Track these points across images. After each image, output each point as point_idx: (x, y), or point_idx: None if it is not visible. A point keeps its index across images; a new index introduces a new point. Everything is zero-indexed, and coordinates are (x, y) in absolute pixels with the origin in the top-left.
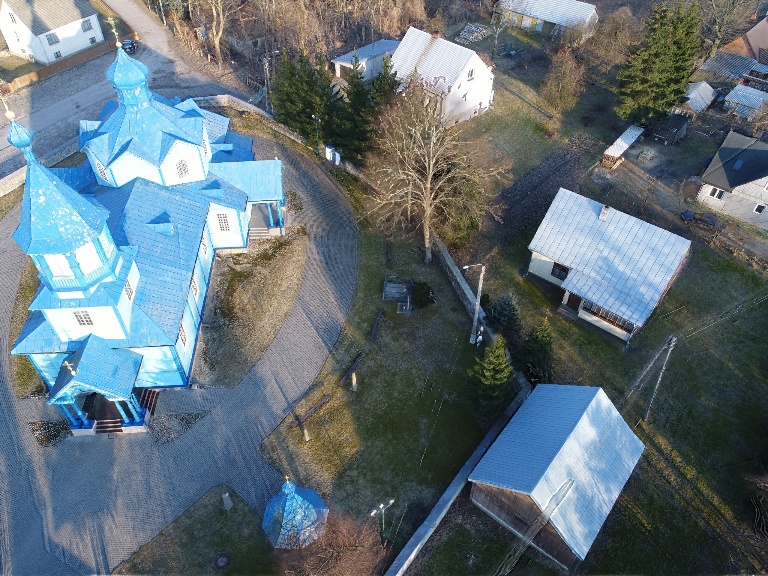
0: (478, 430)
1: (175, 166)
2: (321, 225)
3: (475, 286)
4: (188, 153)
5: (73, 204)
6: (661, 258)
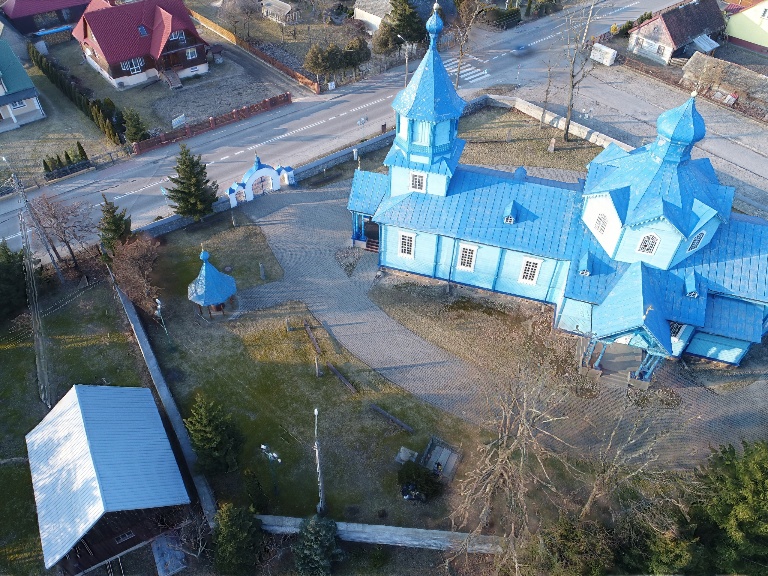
0: None
1: (598, 214)
2: (596, 417)
3: (417, 568)
4: (614, 218)
5: (421, 90)
6: None
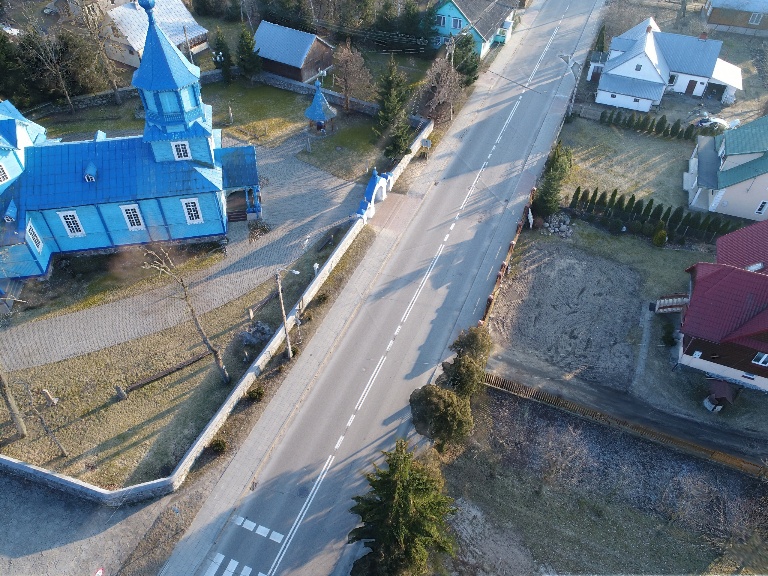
0: (263, 86)
1: None
2: None
3: None
4: None
5: None
6: (174, 3)
